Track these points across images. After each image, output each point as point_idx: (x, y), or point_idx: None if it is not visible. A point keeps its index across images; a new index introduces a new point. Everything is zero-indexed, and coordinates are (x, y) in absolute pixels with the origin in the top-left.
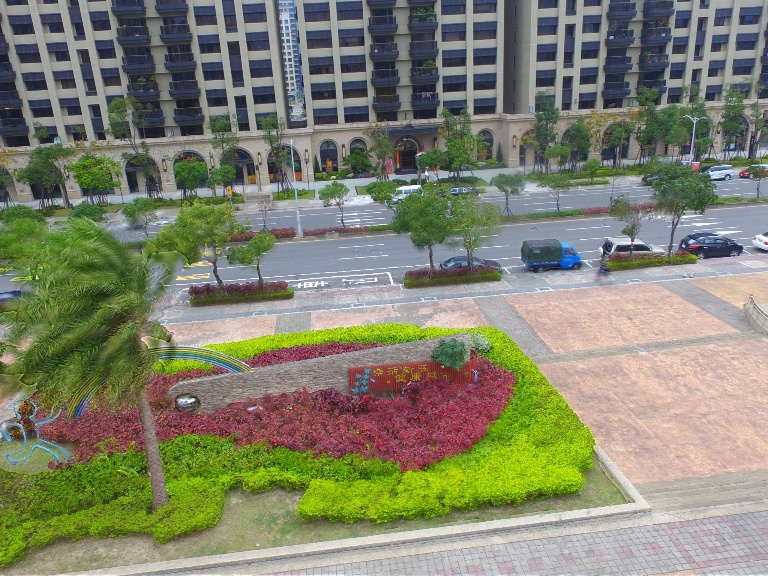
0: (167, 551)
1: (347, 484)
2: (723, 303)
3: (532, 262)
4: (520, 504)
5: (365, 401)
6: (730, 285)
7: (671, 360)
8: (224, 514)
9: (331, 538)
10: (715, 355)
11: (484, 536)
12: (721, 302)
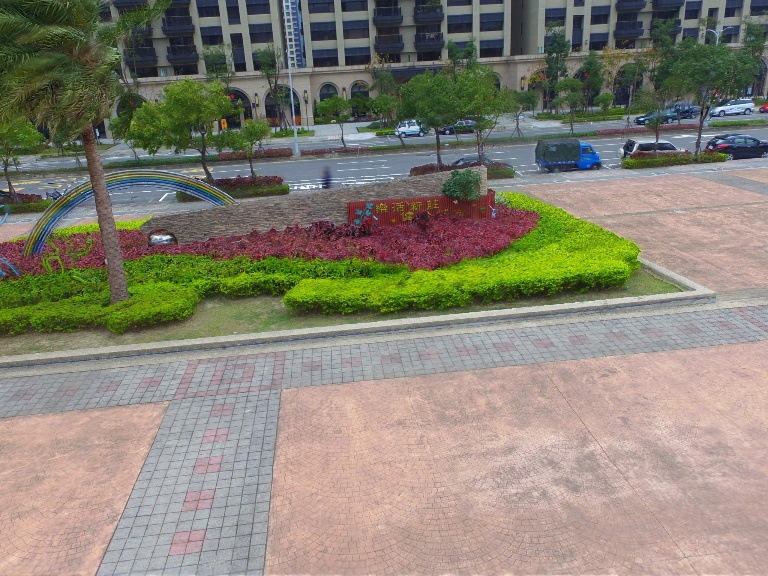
0: (124, 340)
1: (345, 280)
2: (761, 183)
3: (547, 161)
4: (555, 297)
5: (366, 223)
6: (766, 173)
7: (712, 215)
8: (196, 313)
9: (325, 326)
10: (762, 210)
11: (513, 322)
12: (759, 183)
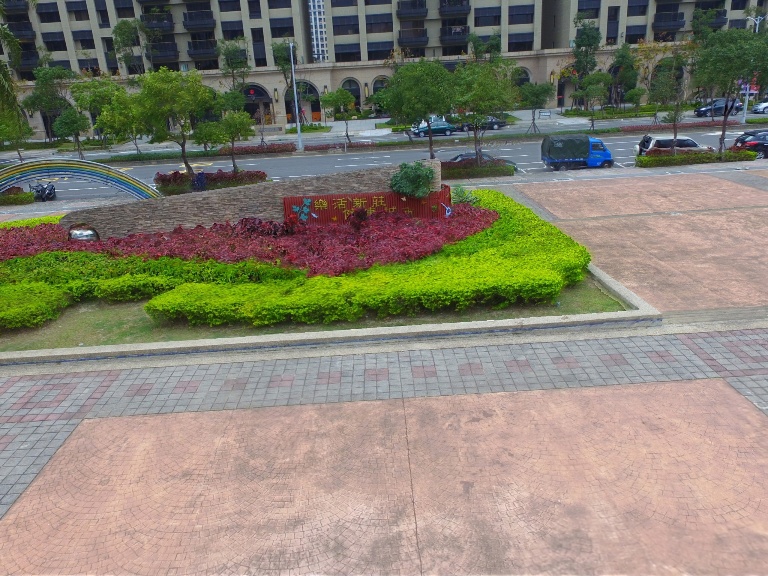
0: None
1: (228, 286)
2: None
3: (553, 158)
4: (467, 313)
5: (290, 221)
6: None
7: (713, 218)
8: (59, 319)
9: (184, 340)
10: None
11: (403, 342)
12: None
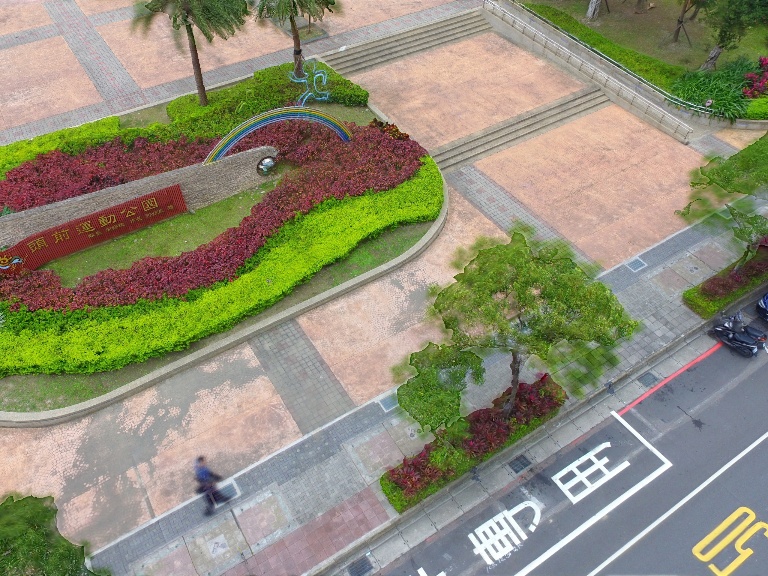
0: None
1: None
2: None
3: None
4: None
5: None
6: None
7: None
8: None
9: None
10: None
11: None
12: None
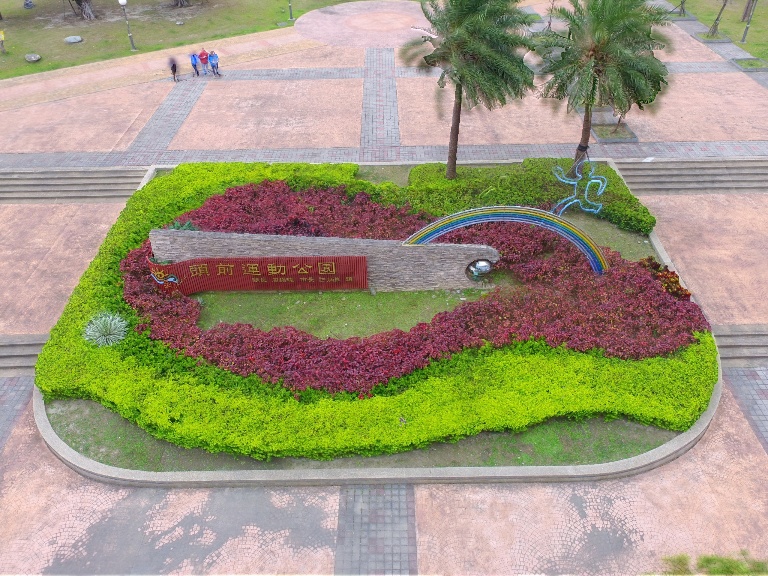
0: None
1: None
2: None
3: None
4: None
5: None
6: None
7: None
8: None
9: None
10: None
11: None
12: None
